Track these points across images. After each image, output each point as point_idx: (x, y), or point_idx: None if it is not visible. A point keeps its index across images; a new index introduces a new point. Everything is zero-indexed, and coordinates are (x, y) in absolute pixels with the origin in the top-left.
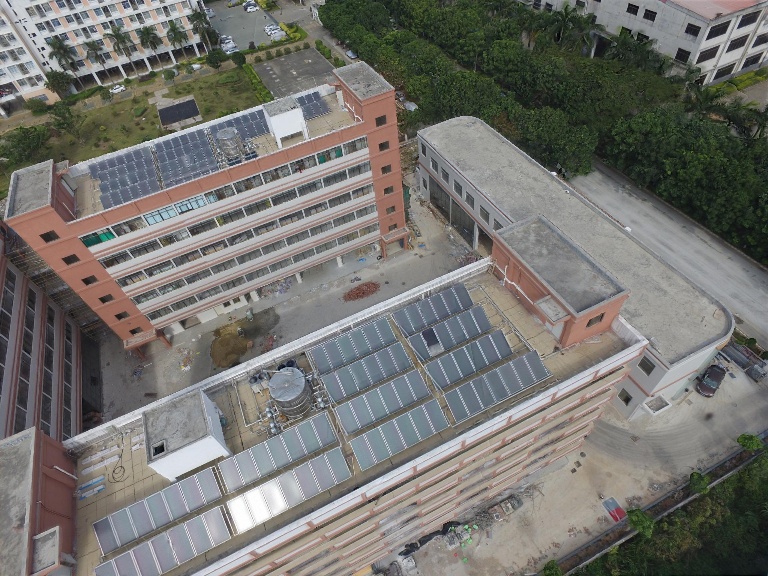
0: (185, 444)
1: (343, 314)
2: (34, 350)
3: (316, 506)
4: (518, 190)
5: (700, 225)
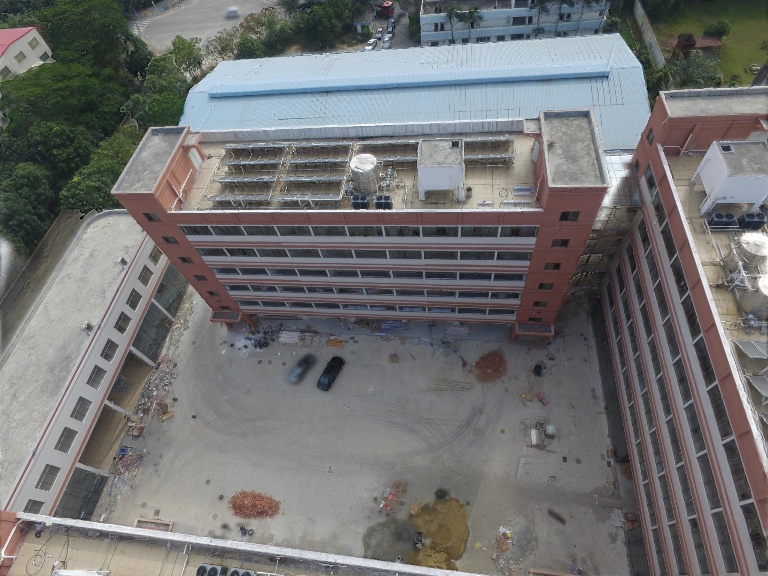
0: (438, 141)
1: (294, 484)
2: (690, 539)
3: None
4: (13, 421)
5: None
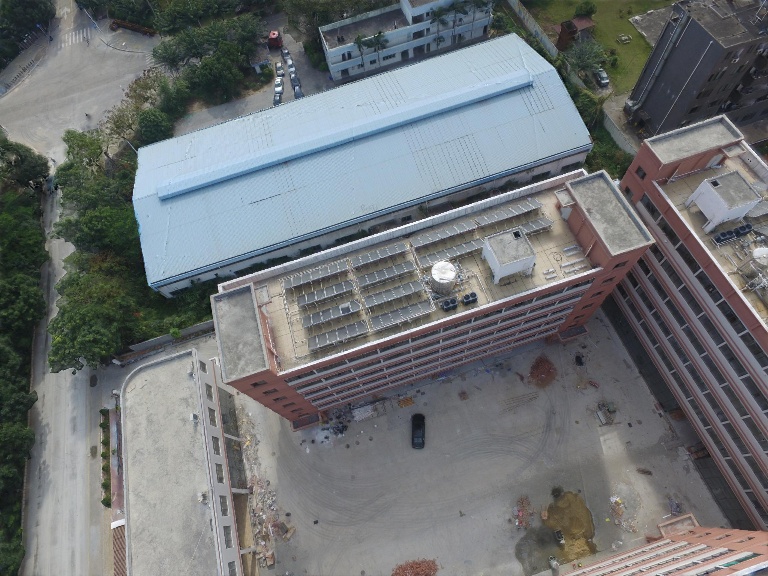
0: (501, 235)
1: (438, 539)
2: None
3: (430, 231)
4: None
5: None
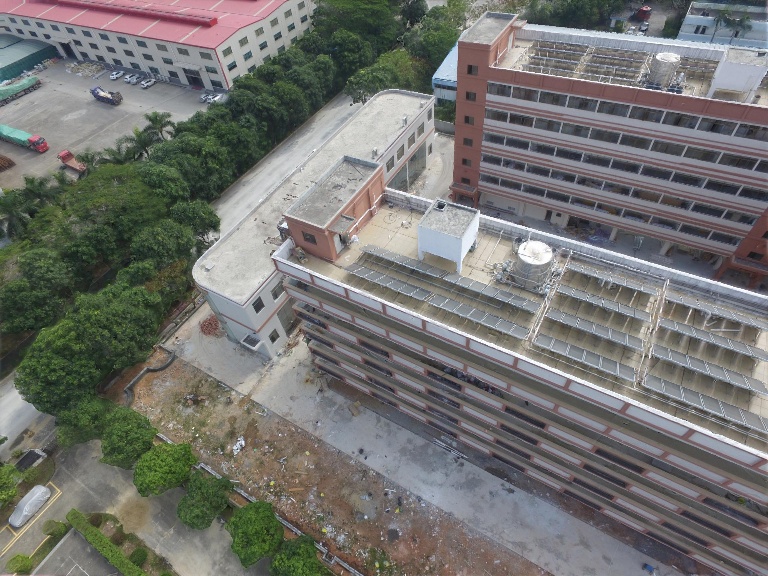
0: (744, 50)
1: None
2: None
3: None
4: None
5: (239, 179)
